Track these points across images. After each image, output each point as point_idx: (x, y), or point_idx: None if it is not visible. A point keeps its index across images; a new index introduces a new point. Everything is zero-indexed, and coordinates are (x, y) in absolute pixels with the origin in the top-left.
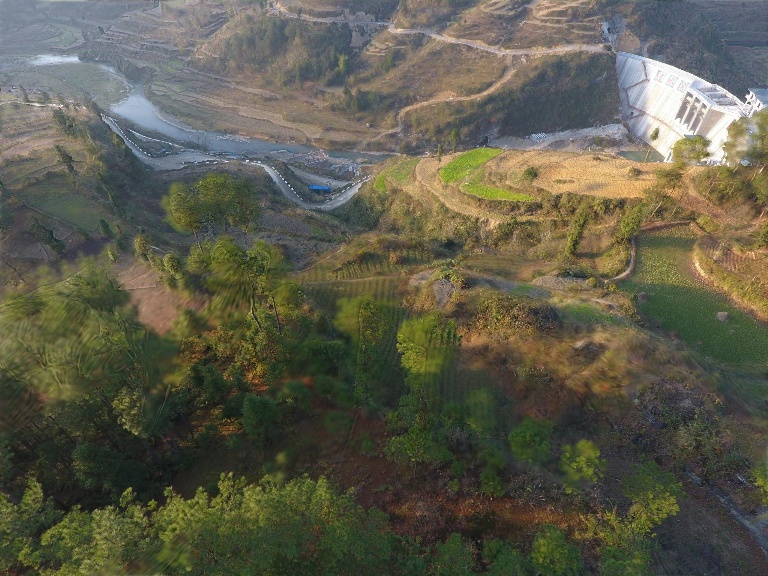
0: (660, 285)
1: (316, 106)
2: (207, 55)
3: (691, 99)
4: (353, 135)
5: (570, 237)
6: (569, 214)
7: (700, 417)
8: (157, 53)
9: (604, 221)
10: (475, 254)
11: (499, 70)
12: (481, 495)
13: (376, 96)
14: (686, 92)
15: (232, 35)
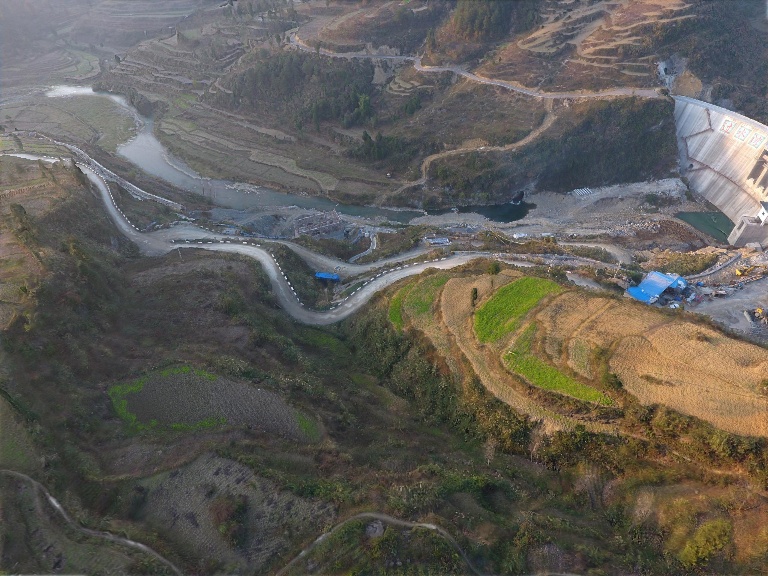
0: None
1: (333, 151)
2: (220, 91)
3: None
4: (372, 187)
5: (693, 551)
6: (667, 437)
7: None
8: (171, 86)
9: (726, 465)
10: None
11: (538, 116)
12: None
13: (398, 143)
14: (763, 150)
15: (246, 71)
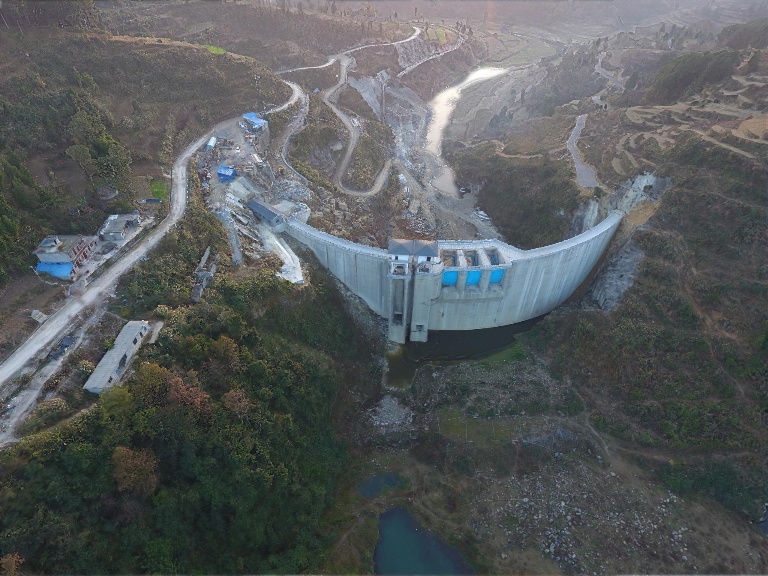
0: None
1: None
2: (556, 66)
3: None
4: (461, 133)
5: None
6: None
7: None
8: None
9: None
10: None
11: None
12: None
13: (501, 122)
14: None
15: (564, 56)
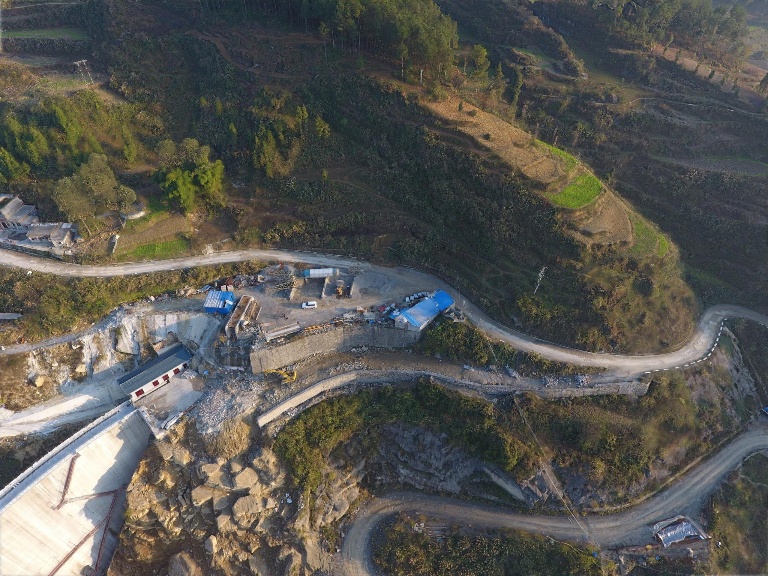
0: None
1: None
2: None
3: None
4: None
5: None
6: None
7: (523, 8)
8: None
9: None
10: None
11: None
12: (564, 1)
13: None
14: None
15: None
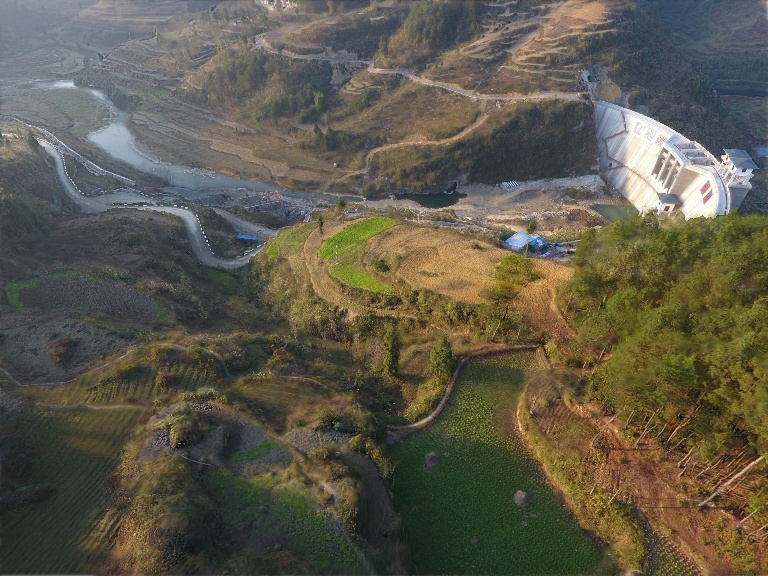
0: (462, 441)
1: (287, 143)
2: (190, 87)
3: (666, 155)
4: (318, 175)
5: (384, 360)
6: (428, 314)
7: None
8: (147, 82)
9: (460, 328)
10: (260, 378)
11: (472, 115)
12: None
13: (346, 136)
14: (662, 148)
15: (214, 68)
